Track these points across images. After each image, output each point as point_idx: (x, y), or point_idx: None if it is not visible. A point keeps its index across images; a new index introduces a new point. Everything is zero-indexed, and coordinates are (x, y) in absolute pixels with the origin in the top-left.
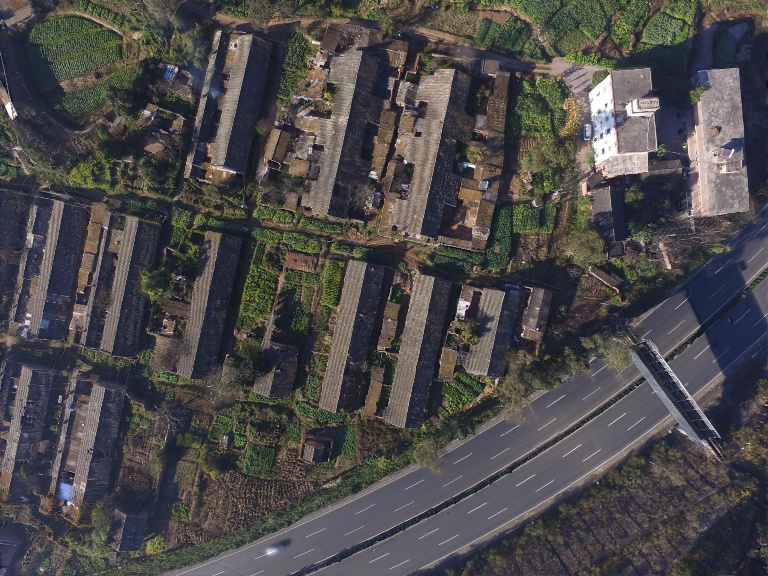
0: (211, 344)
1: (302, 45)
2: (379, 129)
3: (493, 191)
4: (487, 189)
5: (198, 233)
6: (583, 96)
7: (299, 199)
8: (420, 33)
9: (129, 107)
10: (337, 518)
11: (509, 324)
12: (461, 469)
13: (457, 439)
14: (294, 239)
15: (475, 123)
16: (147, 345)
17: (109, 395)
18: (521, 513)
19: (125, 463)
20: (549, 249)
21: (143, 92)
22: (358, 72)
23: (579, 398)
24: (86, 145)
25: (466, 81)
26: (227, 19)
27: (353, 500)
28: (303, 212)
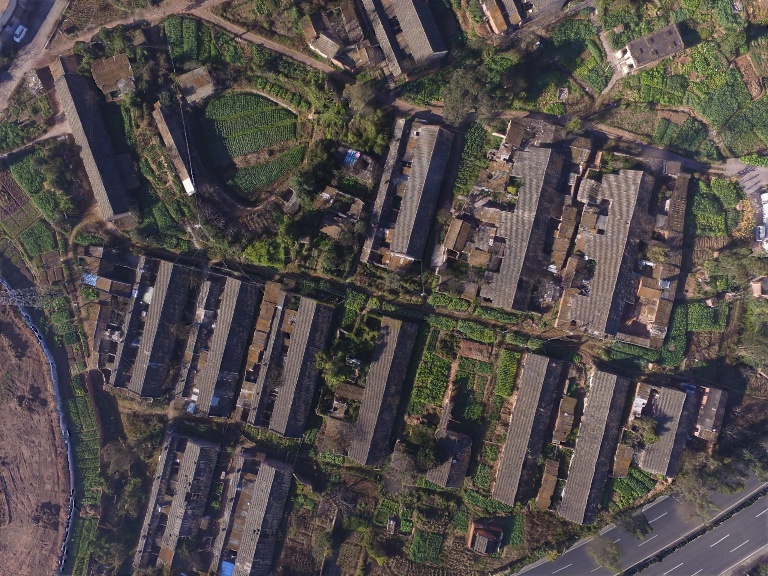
0: (385, 430)
1: (481, 135)
2: (561, 224)
3: (671, 290)
4: (666, 288)
5: (372, 317)
6: (755, 197)
7: (478, 289)
8: (599, 129)
9: (310, 190)
10: None
11: (686, 424)
12: None
13: (607, 525)
14: (470, 328)
15: (656, 222)
16: (313, 425)
17: (278, 476)
18: None
19: (287, 543)
20: (720, 347)
21: (324, 175)
22: (546, 169)
23: None
24: (258, 222)
25: (651, 182)
26: (406, 106)
27: None
28: (482, 302)
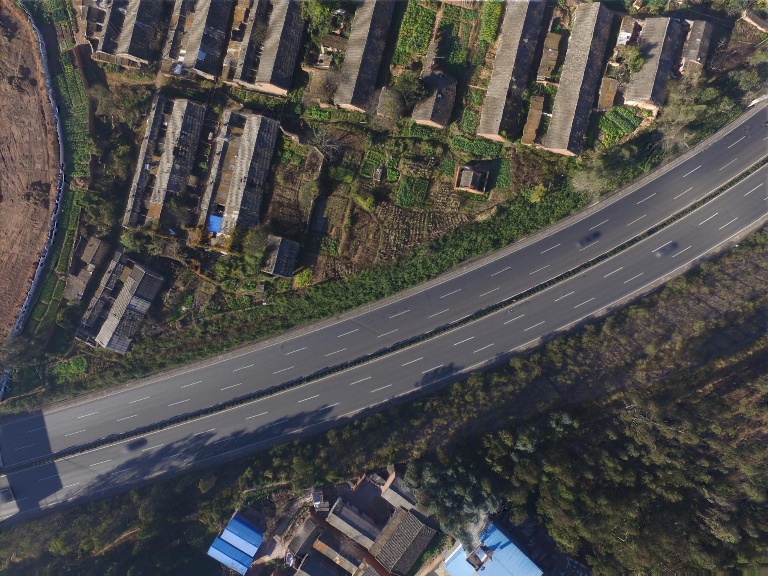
0: (370, 73)
1: None
2: None
3: None
4: None
5: None
6: None
7: None
8: None
9: None
10: (472, 279)
11: (671, 53)
12: (597, 235)
13: (595, 203)
14: None
15: None
16: (299, 84)
17: (264, 124)
18: (657, 278)
19: (275, 198)
20: None
21: None
22: None
23: (715, 169)
24: None
25: None
26: None
27: (489, 262)
28: None
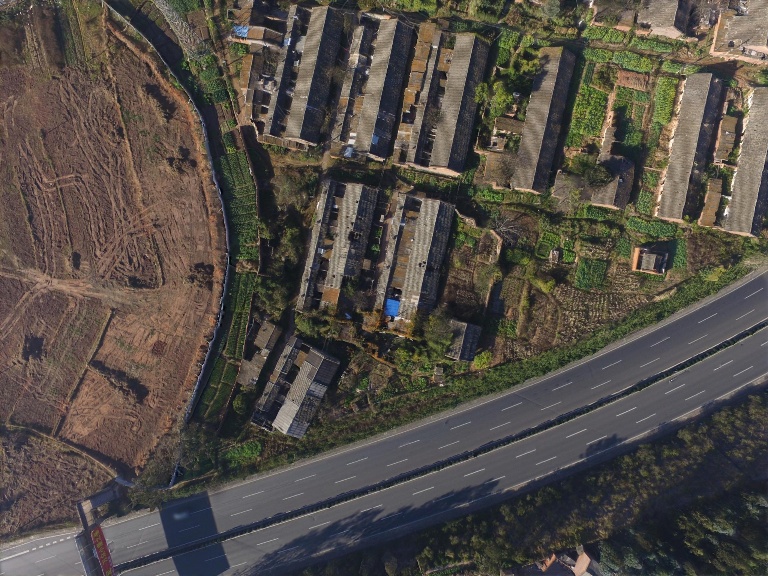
0: (548, 157)
1: None
2: None
3: None
4: None
5: (528, 52)
6: None
7: (635, 16)
8: None
9: None
10: (633, 350)
11: None
12: (752, 303)
13: (750, 273)
14: (626, 57)
15: None
16: (470, 165)
17: (442, 209)
18: None
19: (450, 280)
20: None
21: None
22: None
23: None
24: None
25: None
26: None
27: (648, 333)
28: (639, 29)
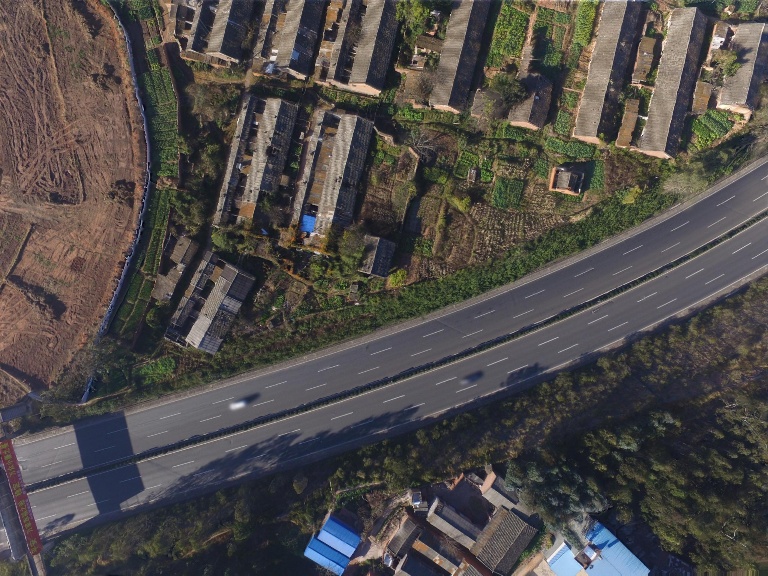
0: (466, 75)
1: None
2: None
3: None
4: None
5: None
6: None
7: None
8: None
9: None
10: (556, 280)
11: (764, 58)
12: (678, 236)
13: (676, 205)
14: None
15: None
16: (392, 84)
17: (360, 125)
18: (738, 279)
19: (367, 198)
20: None
21: None
22: None
23: None
24: None
25: None
26: None
27: (572, 263)
28: None
